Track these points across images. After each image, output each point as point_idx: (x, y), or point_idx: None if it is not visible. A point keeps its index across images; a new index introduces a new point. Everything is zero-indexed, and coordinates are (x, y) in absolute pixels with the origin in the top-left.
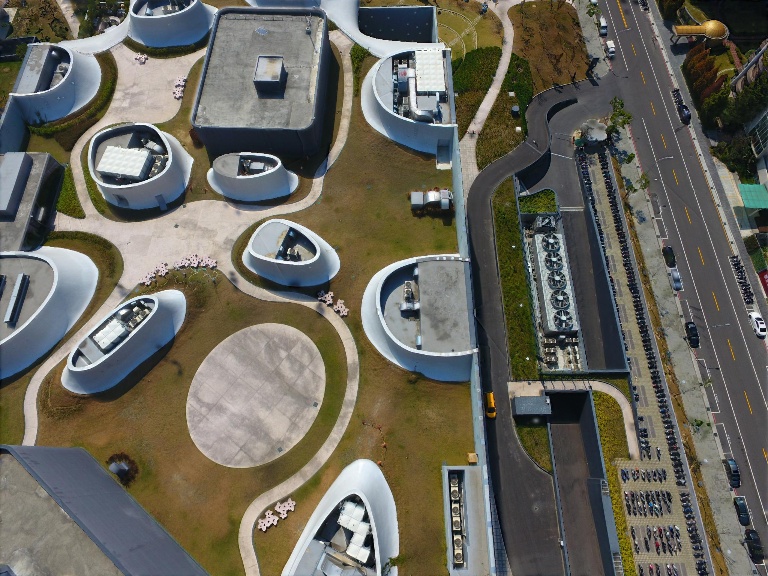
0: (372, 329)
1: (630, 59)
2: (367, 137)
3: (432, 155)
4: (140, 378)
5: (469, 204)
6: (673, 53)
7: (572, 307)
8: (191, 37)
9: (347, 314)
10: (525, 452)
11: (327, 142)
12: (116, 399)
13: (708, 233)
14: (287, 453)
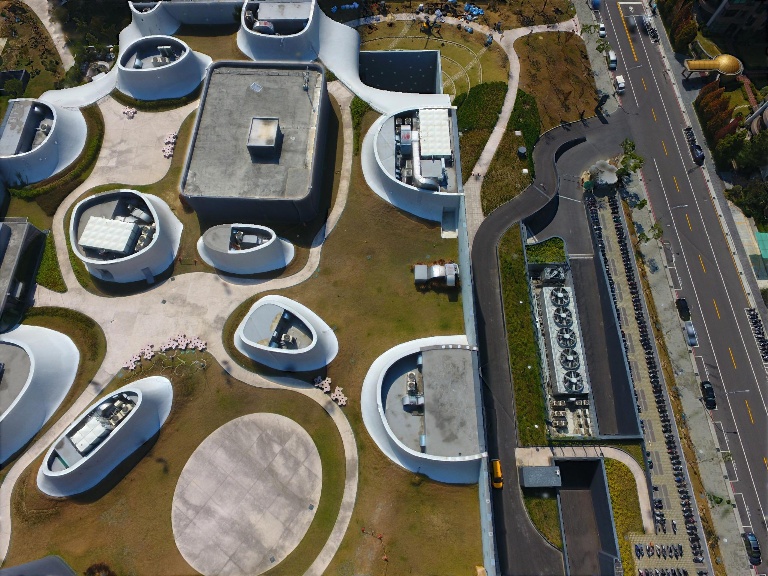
0: (372, 423)
1: (640, 95)
2: (368, 201)
3: (437, 223)
4: (122, 476)
5: (474, 252)
6: (685, 88)
7: (582, 367)
8: (182, 89)
9: (346, 403)
10: (533, 526)
11: (325, 206)
12: (96, 501)
13: (723, 283)
14: (280, 564)
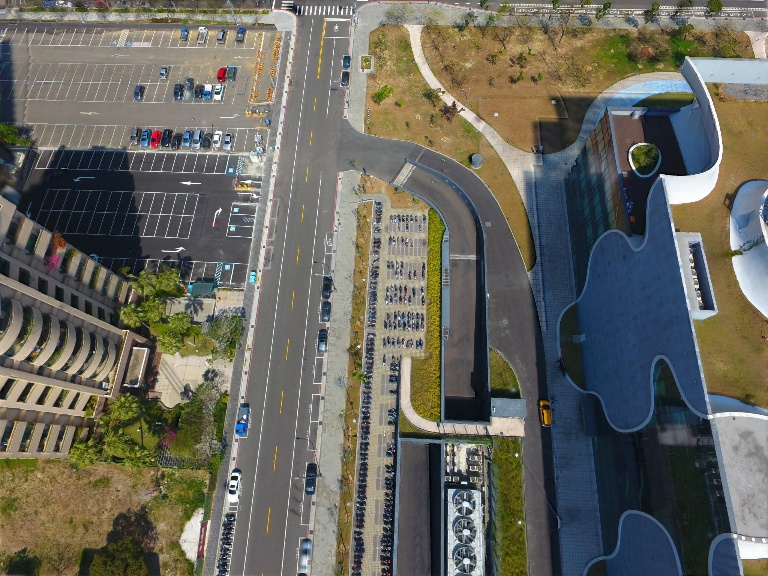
0: None
1: None
2: None
3: None
4: None
5: None
6: None
7: (451, 520)
8: None
9: None
10: (511, 367)
11: None
12: None
13: None
14: None
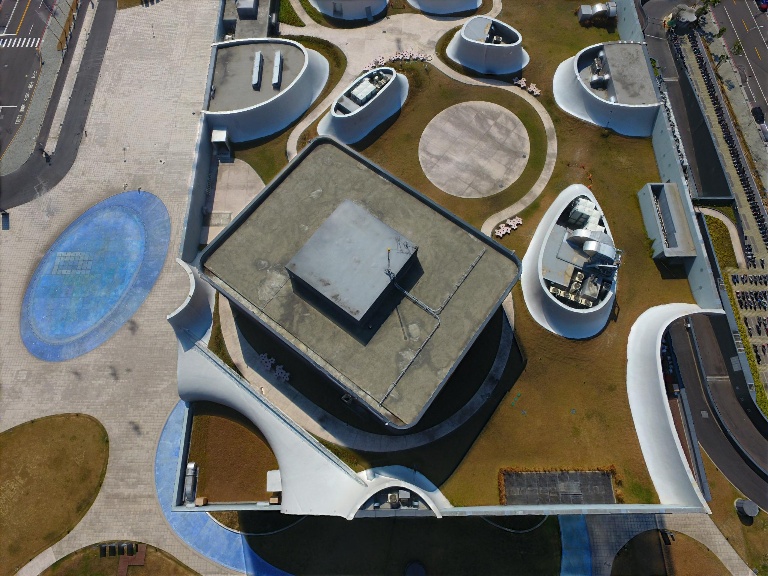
0: (566, 100)
1: None
2: None
3: None
4: (378, 137)
5: None
6: None
7: (681, 148)
8: None
9: (540, 94)
10: None
11: None
12: (361, 151)
13: None
14: (507, 188)
